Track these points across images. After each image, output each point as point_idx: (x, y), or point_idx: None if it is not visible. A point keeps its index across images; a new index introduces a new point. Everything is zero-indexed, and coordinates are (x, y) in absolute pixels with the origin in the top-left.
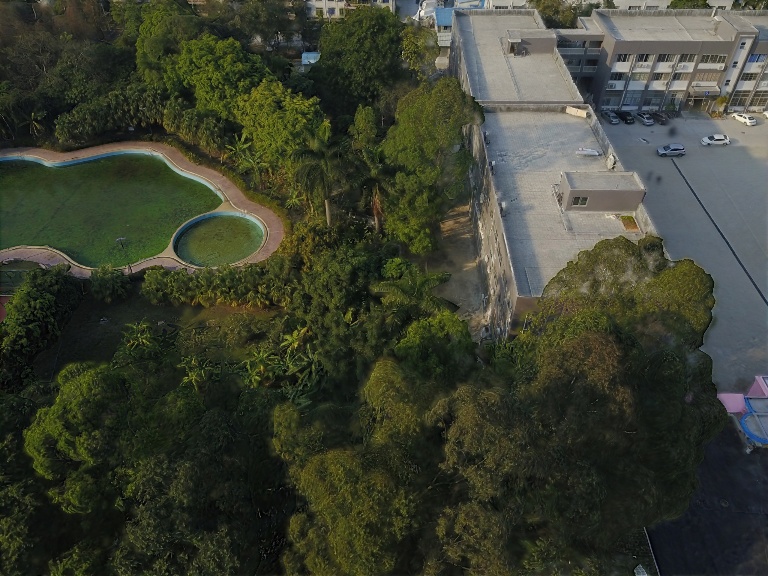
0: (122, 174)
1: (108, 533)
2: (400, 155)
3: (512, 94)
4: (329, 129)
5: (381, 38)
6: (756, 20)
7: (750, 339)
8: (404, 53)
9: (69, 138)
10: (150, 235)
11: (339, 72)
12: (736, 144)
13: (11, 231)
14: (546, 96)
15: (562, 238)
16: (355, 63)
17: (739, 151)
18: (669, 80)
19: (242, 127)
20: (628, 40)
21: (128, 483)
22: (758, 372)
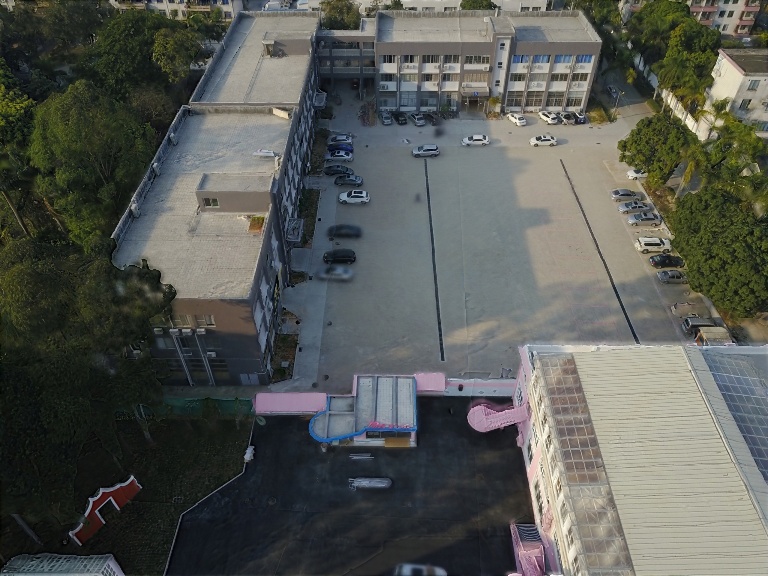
0: None
1: None
2: (35, 157)
3: (240, 96)
4: None
5: (132, 40)
6: (537, 21)
7: (399, 338)
8: (154, 55)
9: None
10: None
11: (96, 74)
12: (497, 144)
13: None
14: (273, 98)
15: (179, 239)
16: (104, 65)
17: (495, 151)
18: (439, 81)
19: None
20: (395, 41)
21: None
22: (388, 371)
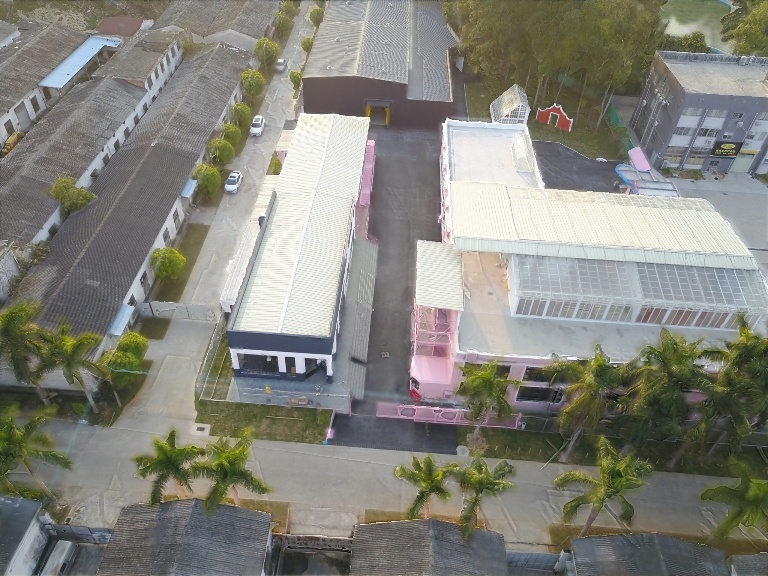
0: None
1: None
2: None
3: None
4: None
5: None
6: None
7: None
8: None
9: None
10: None
11: None
12: None
13: (668, 13)
14: None
15: (729, 78)
16: None
17: None
18: None
19: None
20: None
21: None
22: None
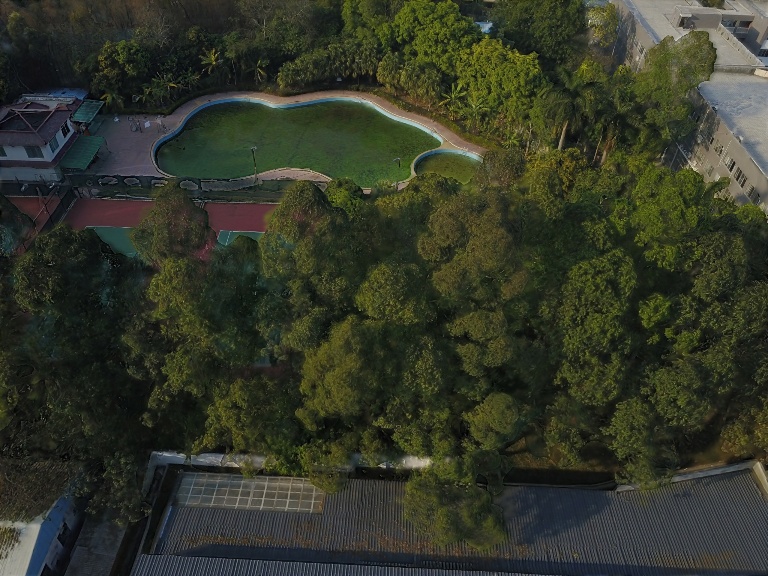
0: (342, 117)
1: (663, 291)
2: (655, 94)
3: None
4: (586, 72)
5: (571, 8)
6: None
7: None
8: (591, 22)
9: (288, 85)
10: (389, 165)
11: (528, 37)
12: None
13: (266, 157)
14: (726, 62)
15: None
16: (548, 28)
17: None
18: None
19: (452, 79)
20: None
21: (692, 252)
22: None
